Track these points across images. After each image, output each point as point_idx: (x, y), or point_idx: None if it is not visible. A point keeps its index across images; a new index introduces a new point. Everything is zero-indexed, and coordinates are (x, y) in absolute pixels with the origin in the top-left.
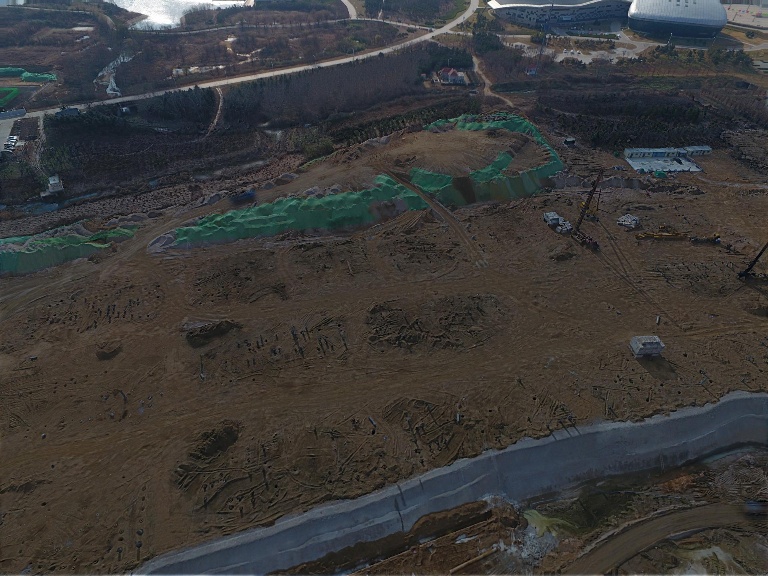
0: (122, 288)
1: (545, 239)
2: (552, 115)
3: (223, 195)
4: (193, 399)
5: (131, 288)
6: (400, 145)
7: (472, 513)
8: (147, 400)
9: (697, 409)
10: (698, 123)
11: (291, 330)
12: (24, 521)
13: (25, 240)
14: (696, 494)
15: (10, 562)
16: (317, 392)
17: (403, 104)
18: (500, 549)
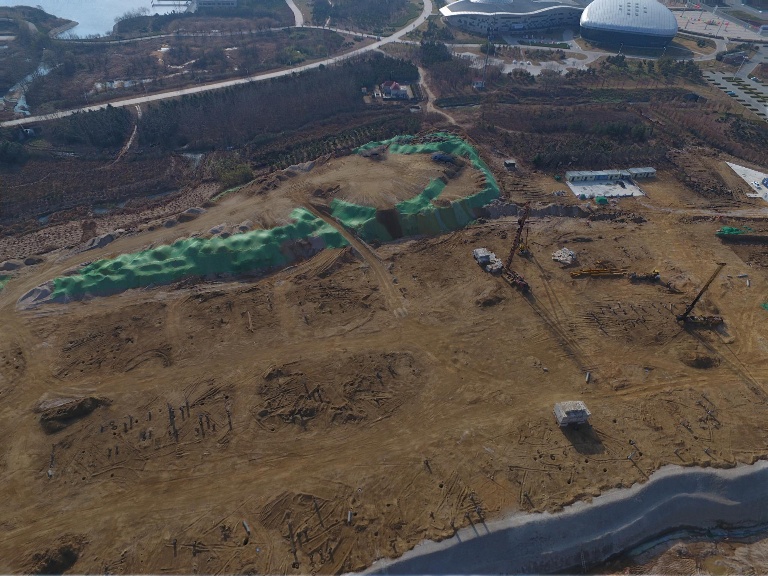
0: None
1: (473, 280)
2: (494, 133)
3: (117, 235)
4: (32, 506)
5: None
6: (325, 172)
7: None
8: None
9: (623, 492)
10: (644, 141)
11: (169, 406)
12: None
13: None
14: None
15: None
16: (186, 489)
17: (338, 122)
18: None
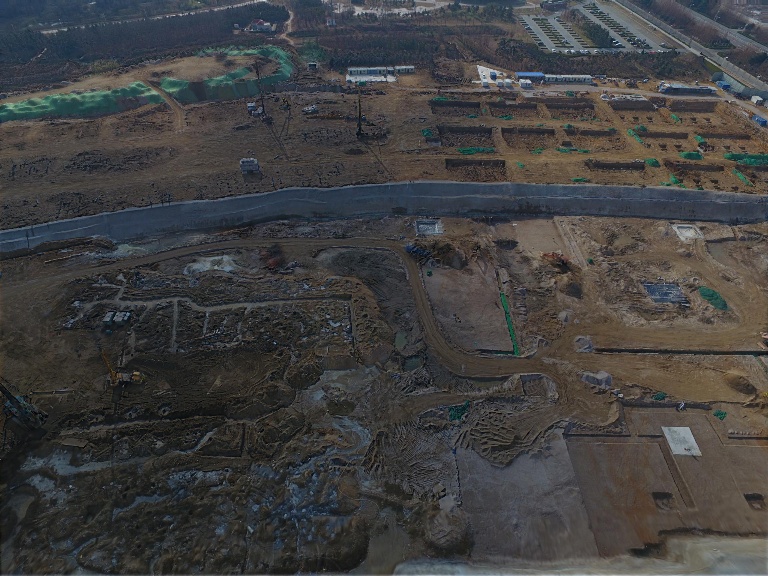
0: None
1: (239, 119)
2: (317, 50)
3: (8, 95)
4: None
5: None
6: (167, 65)
7: (79, 241)
8: None
9: (257, 194)
10: None
11: (13, 164)
12: None
13: None
14: (235, 236)
15: None
16: (10, 190)
17: (202, 44)
18: (84, 254)
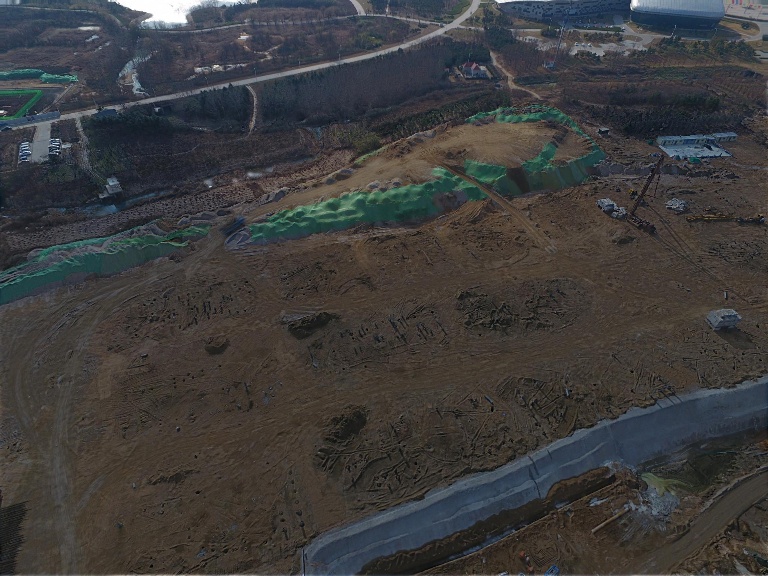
0: (211, 285)
1: (604, 224)
2: (580, 106)
3: (287, 191)
4: (313, 387)
5: (220, 285)
6: (447, 138)
7: (598, 478)
8: (269, 390)
9: None
10: (718, 111)
11: (388, 318)
12: (184, 509)
13: (102, 241)
14: None
15: (183, 547)
16: (429, 375)
17: (435, 98)
18: (631, 509)
